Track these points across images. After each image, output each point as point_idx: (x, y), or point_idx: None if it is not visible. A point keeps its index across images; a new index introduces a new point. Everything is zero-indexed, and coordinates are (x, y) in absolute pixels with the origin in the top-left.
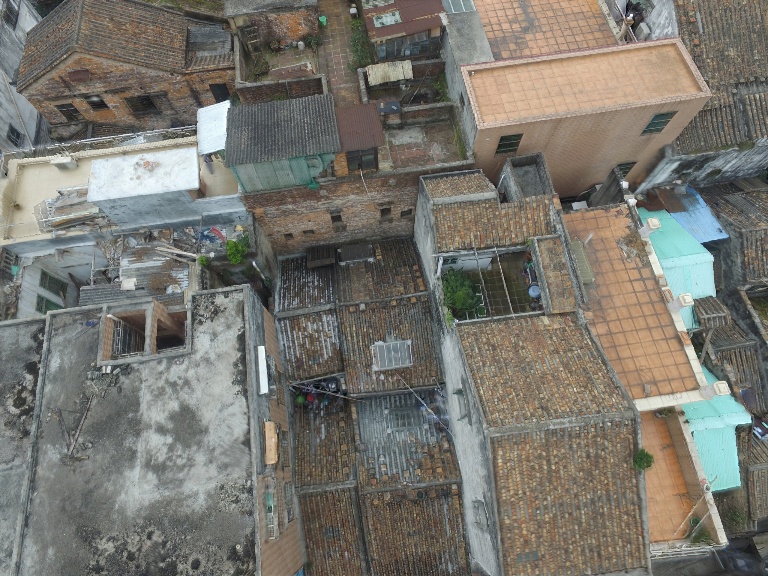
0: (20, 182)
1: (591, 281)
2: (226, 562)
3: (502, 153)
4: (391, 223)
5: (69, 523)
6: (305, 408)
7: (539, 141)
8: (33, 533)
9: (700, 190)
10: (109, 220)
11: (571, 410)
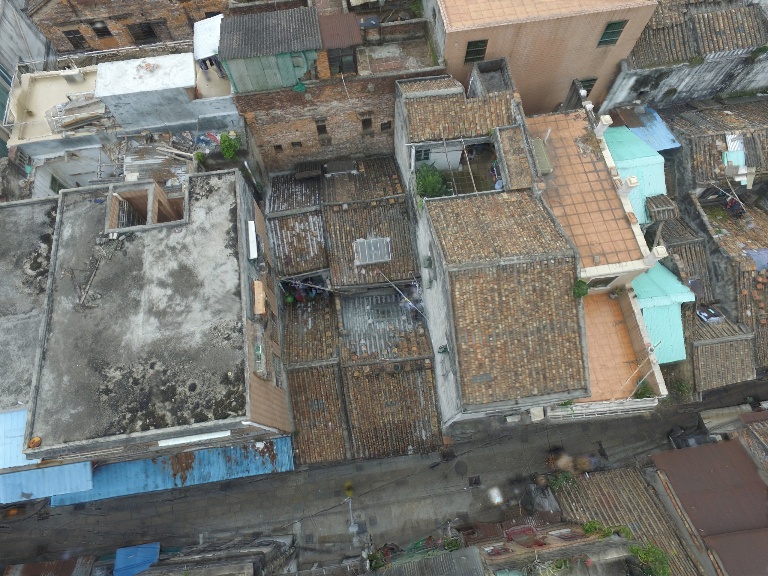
0: (32, 93)
1: (549, 171)
2: (219, 385)
3: (471, 62)
4: (373, 138)
5: (81, 357)
6: (294, 306)
7: (504, 49)
8: (50, 365)
9: (658, 110)
10: (114, 120)
11: (520, 252)
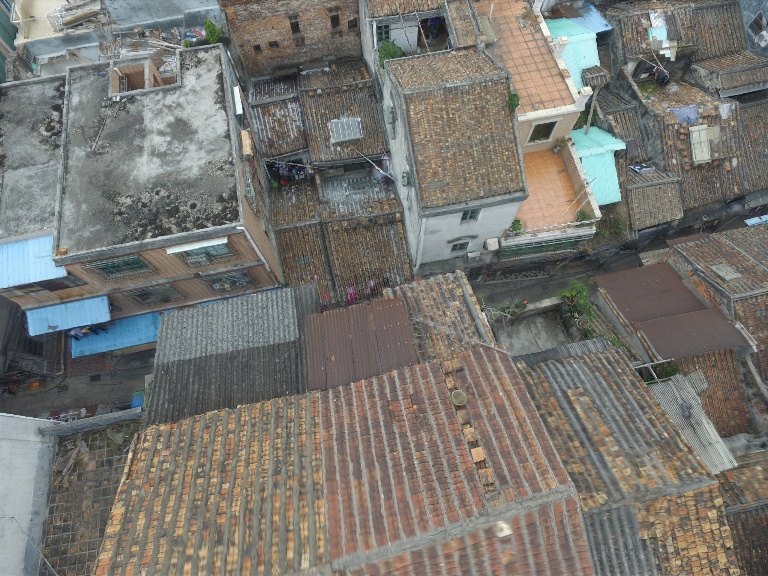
0: (33, 2)
1: (494, 41)
2: (216, 204)
3: None
4: (341, 37)
5: (96, 190)
6: (279, 189)
7: None
8: (69, 197)
9: (595, 5)
10: (109, 16)
11: None
